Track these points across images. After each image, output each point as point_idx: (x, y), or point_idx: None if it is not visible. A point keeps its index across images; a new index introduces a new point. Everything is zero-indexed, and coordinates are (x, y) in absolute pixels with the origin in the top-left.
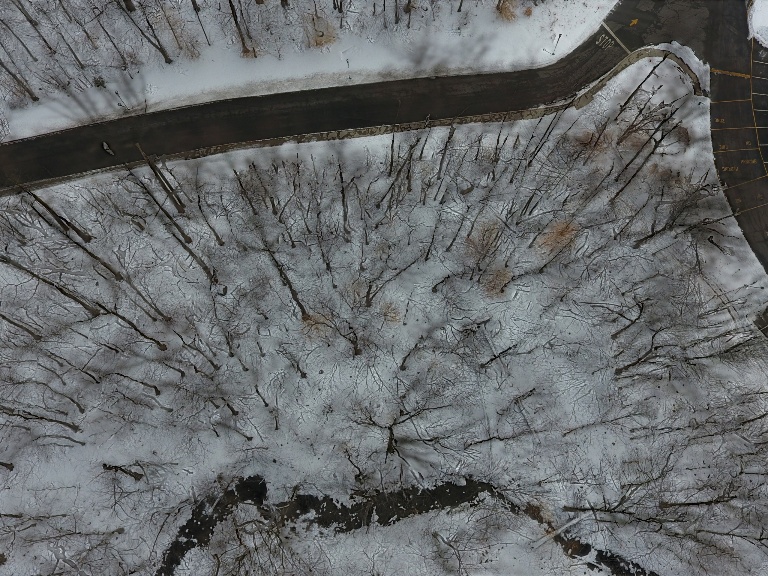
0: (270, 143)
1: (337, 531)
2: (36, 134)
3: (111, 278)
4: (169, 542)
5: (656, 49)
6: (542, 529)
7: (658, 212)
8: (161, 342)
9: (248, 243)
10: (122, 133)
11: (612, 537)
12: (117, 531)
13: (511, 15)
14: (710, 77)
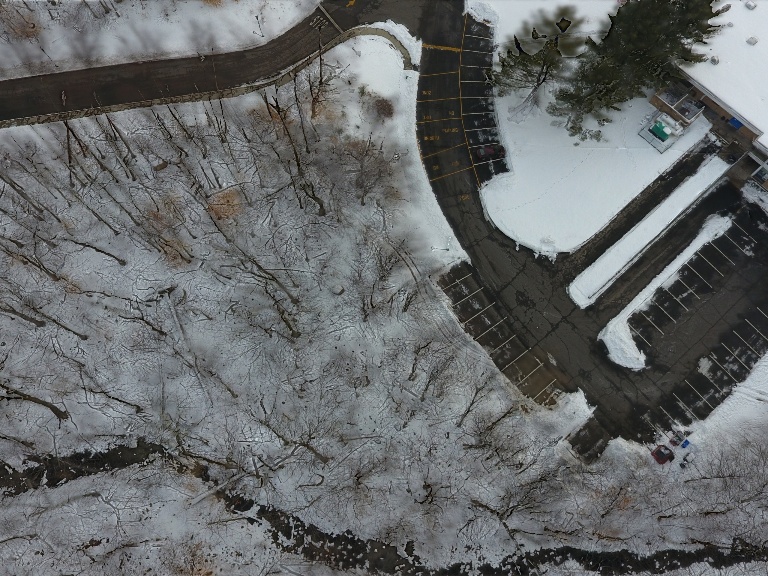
0: None
1: (6, 495)
2: None
3: None
4: None
5: (369, 28)
6: (205, 486)
7: (347, 181)
8: None
9: None
10: None
11: (274, 492)
12: None
13: (217, 0)
14: (421, 52)
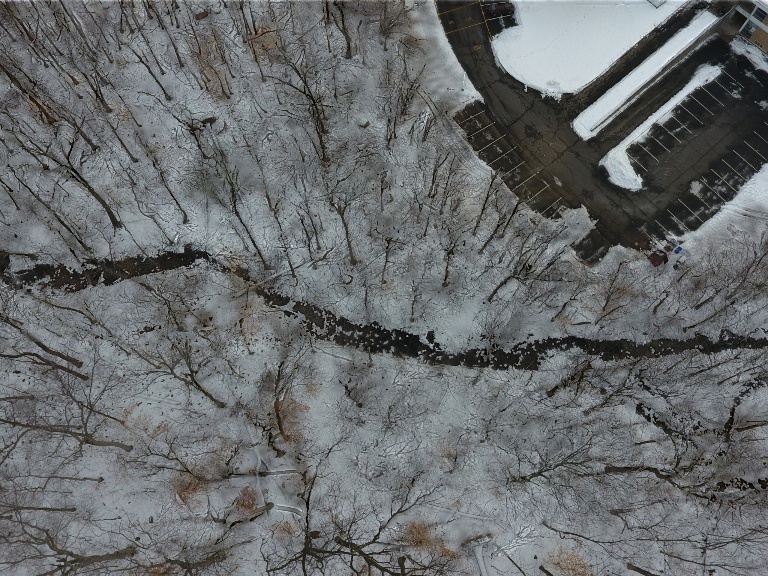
0: None
1: (67, 291)
2: None
3: None
4: None
5: None
6: (246, 284)
7: (371, 29)
8: None
9: (7, 64)
10: None
11: (308, 290)
12: None
13: None
14: None
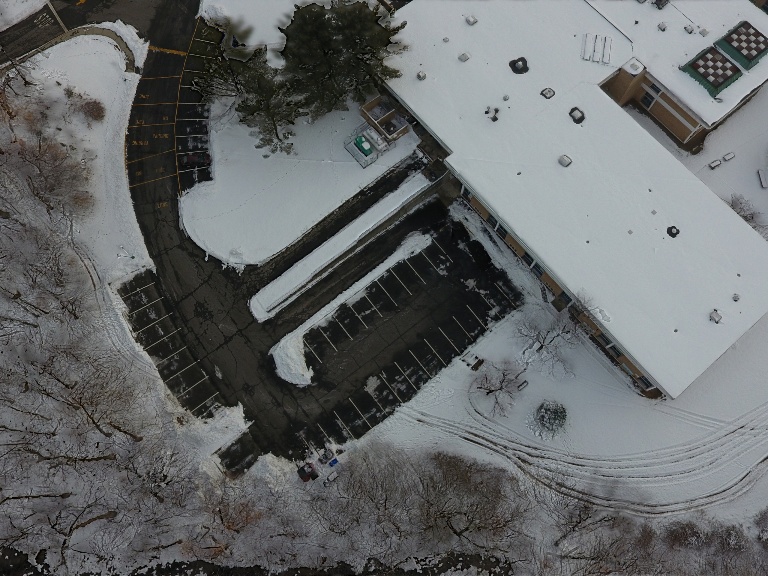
0: None
1: None
2: None
3: None
4: None
5: (96, 27)
6: None
7: (37, 184)
8: None
9: None
10: None
11: None
12: None
13: None
14: (147, 54)
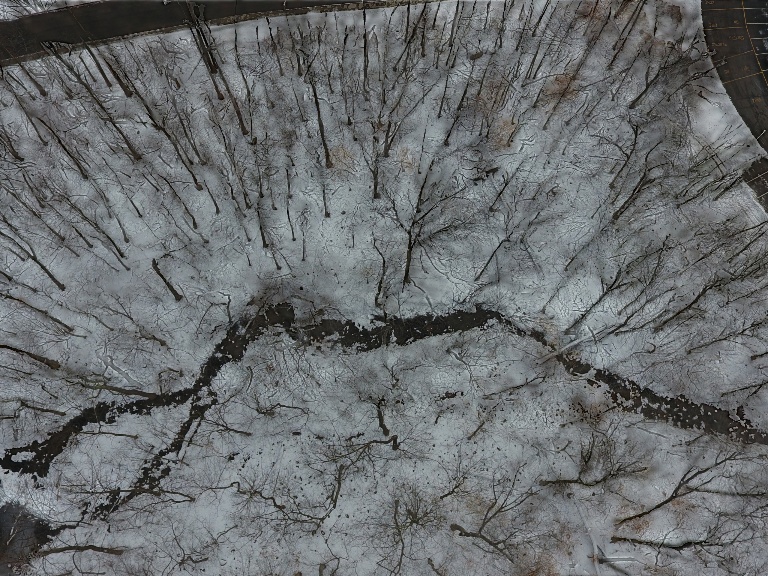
0: (295, 12)
1: (359, 350)
2: (80, 3)
3: (151, 127)
4: (206, 357)
5: None
6: (546, 350)
7: None
8: (197, 183)
9: (275, 100)
10: (159, 3)
11: (610, 358)
12: (160, 342)
13: None
14: None
